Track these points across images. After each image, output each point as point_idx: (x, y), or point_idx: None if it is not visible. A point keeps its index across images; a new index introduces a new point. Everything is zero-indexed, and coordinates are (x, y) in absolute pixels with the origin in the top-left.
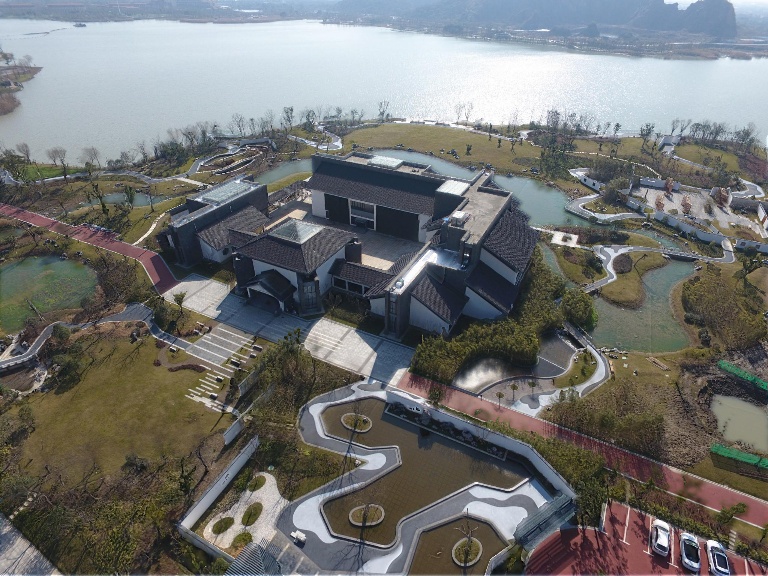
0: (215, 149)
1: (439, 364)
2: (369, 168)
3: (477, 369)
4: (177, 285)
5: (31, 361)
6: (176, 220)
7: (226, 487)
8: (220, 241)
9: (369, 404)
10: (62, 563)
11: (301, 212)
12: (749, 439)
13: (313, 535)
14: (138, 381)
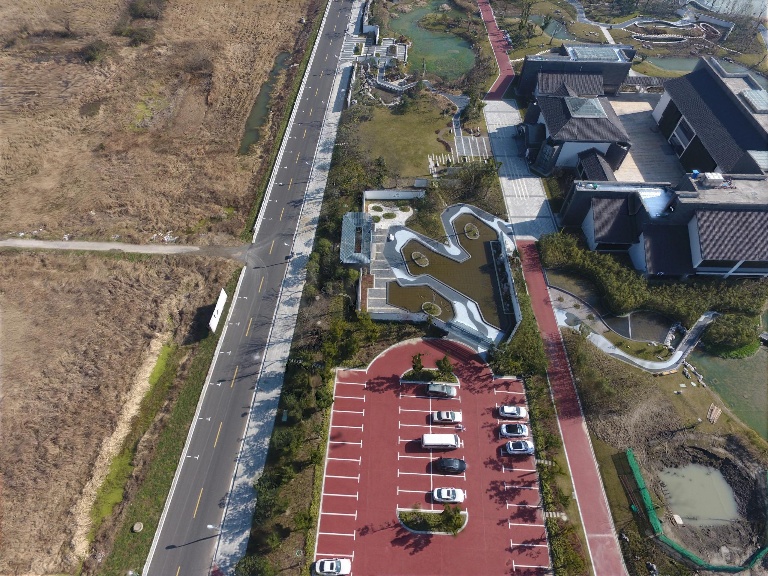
0: (668, 13)
1: (549, 249)
2: (732, 97)
3: (574, 279)
4: (498, 101)
5: (400, 92)
6: (534, 55)
7: (394, 199)
8: (548, 87)
9: (490, 232)
10: (331, 171)
11: (647, 106)
12: (677, 495)
13: (396, 243)
14: (421, 133)
